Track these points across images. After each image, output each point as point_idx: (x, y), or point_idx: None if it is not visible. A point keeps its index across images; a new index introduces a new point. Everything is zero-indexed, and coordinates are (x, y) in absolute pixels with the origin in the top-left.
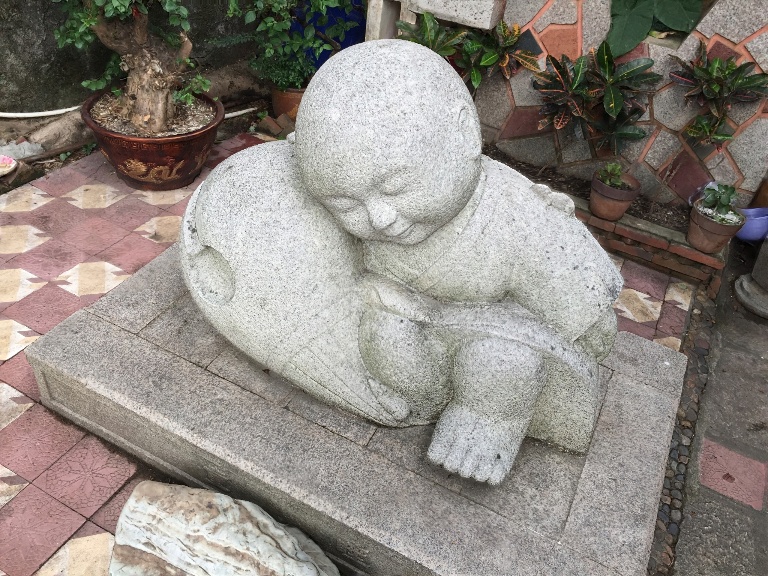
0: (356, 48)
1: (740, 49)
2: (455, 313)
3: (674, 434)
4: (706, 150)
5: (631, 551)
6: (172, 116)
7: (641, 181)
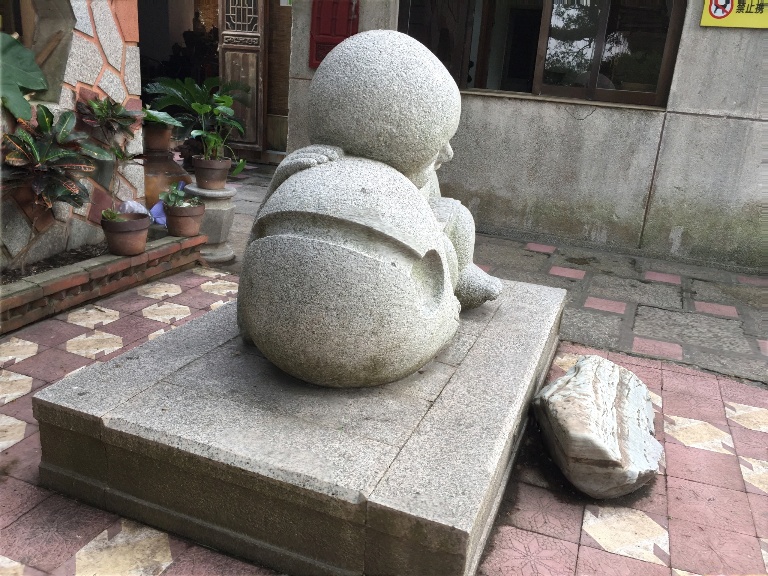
0: (382, 37)
1: (95, 89)
2: (437, 214)
3: None
4: (108, 180)
5: (500, 280)
6: None
7: (79, 233)
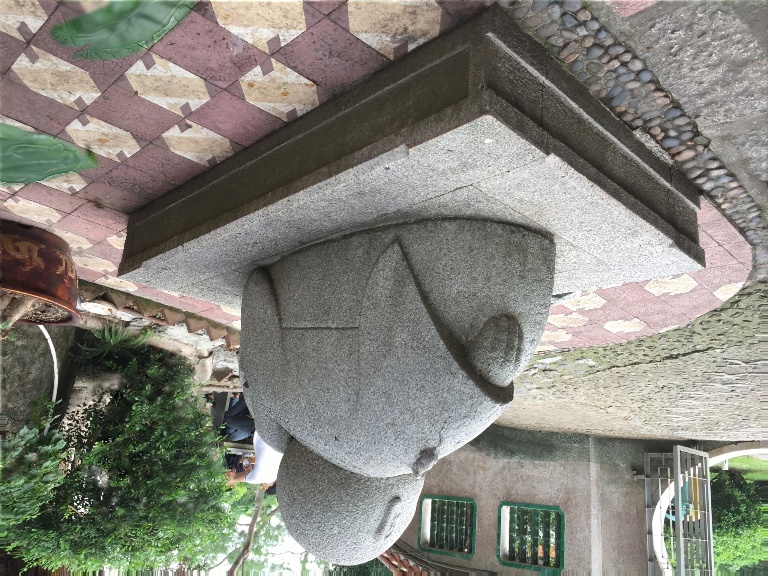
0: None
1: None
2: None
3: (542, 2)
4: None
5: None
6: (5, 297)
7: None
